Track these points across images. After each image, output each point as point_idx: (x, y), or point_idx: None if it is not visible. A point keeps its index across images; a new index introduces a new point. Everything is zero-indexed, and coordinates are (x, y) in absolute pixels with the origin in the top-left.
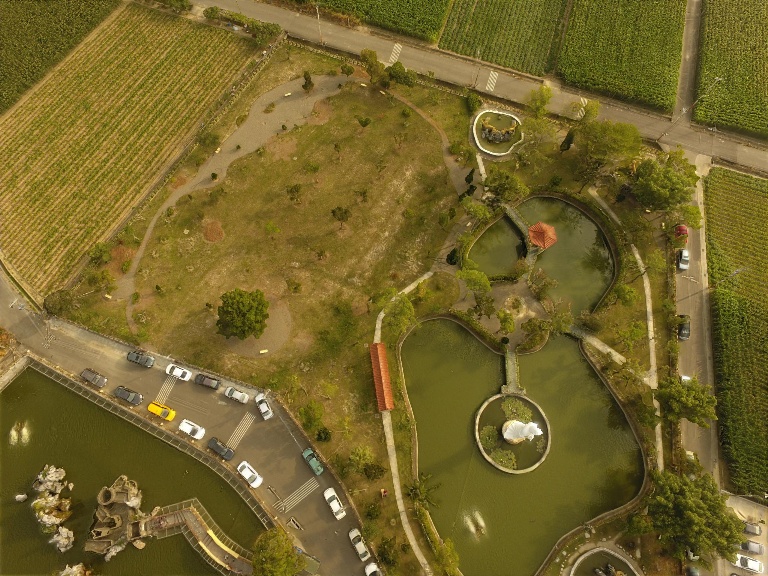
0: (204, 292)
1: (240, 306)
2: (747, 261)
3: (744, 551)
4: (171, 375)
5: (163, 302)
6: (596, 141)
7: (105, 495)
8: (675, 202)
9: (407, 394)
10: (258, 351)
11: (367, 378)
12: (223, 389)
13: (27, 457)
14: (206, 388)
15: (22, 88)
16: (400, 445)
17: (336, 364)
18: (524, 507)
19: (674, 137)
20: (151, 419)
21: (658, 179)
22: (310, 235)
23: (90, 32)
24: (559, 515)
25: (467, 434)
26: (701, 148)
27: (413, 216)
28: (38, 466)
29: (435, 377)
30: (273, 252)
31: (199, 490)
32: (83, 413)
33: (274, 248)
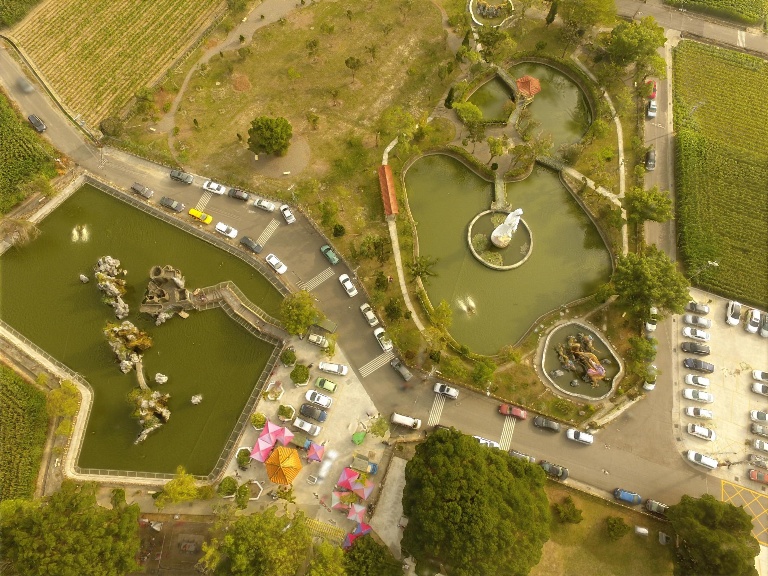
0: (234, 129)
1: (268, 122)
2: (708, 113)
3: (694, 325)
4: (208, 189)
5: (199, 136)
6: (576, 2)
7: (155, 273)
8: (644, 54)
9: (410, 210)
10: (282, 173)
11: (375, 196)
12: (252, 201)
13: (87, 251)
14: (238, 200)
15: None
16: (404, 246)
17: (349, 185)
18: (509, 298)
19: (648, 15)
20: (192, 223)
21: (629, 33)
22: (326, 87)
23: None
24: (538, 301)
25: (461, 240)
26: (672, 24)
27: (416, 74)
28: (97, 258)
29: (434, 198)
30: (294, 100)
31: (233, 277)
32: (133, 219)
33: (294, 97)
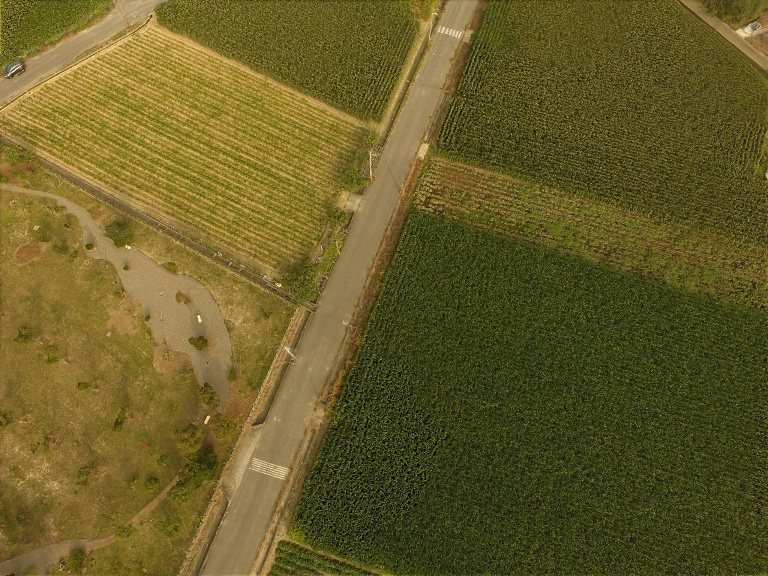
0: None
1: None
2: None
3: None
4: None
5: None
6: None
7: None
8: None
9: None
10: None
11: None
12: None
13: None
14: None
15: (237, 58)
16: None
17: None
18: None
19: None
20: None
21: None
22: None
23: (320, 100)
24: None
25: None
26: None
27: None
28: None
29: None
30: None
31: None
32: None
33: None
